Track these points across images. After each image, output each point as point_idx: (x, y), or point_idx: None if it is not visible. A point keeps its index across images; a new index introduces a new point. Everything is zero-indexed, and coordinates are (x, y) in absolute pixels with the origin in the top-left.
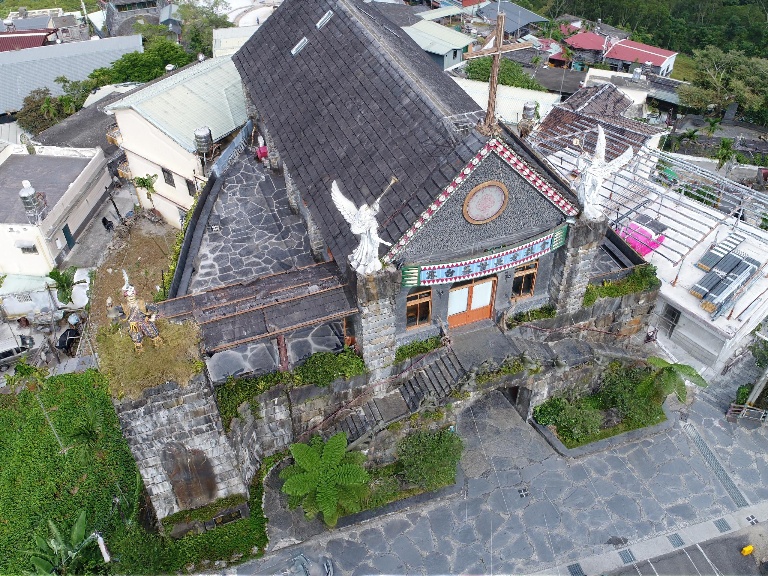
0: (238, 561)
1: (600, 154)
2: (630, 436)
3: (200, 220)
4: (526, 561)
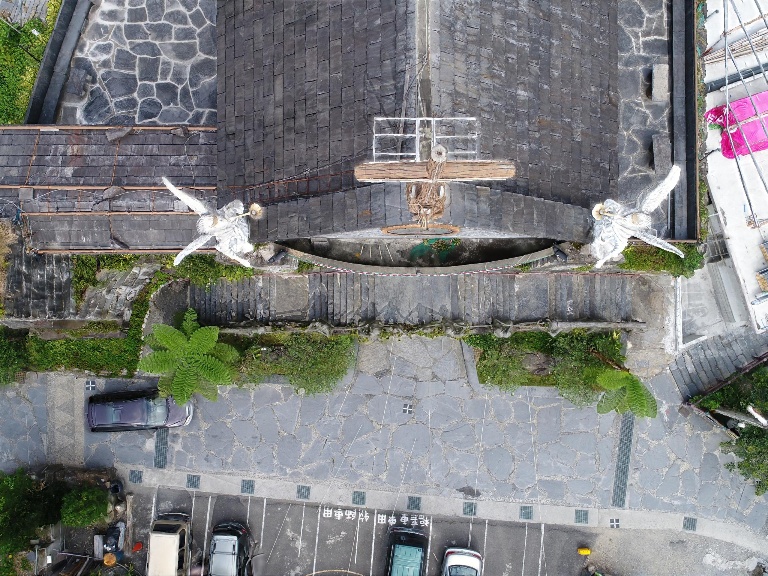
0: (107, 376)
1: (642, 217)
2: (555, 393)
3: None
4: (373, 477)
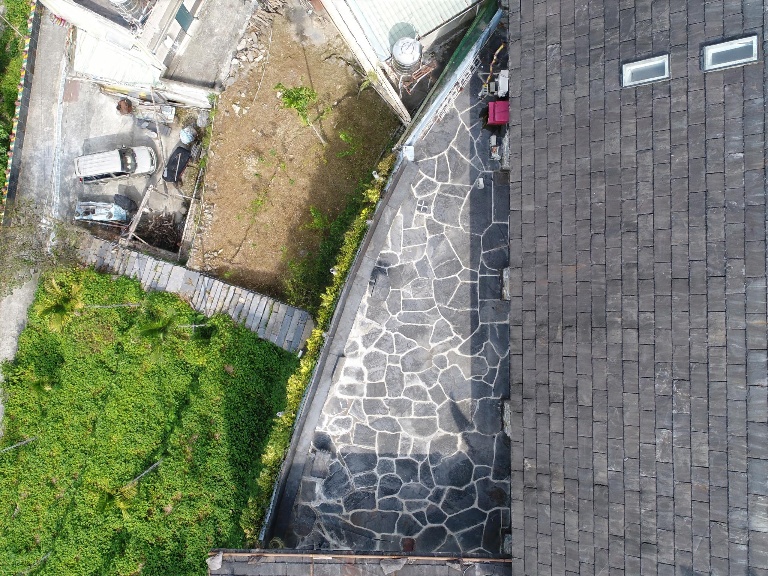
0: None
1: None
2: None
3: (361, 270)
4: None
